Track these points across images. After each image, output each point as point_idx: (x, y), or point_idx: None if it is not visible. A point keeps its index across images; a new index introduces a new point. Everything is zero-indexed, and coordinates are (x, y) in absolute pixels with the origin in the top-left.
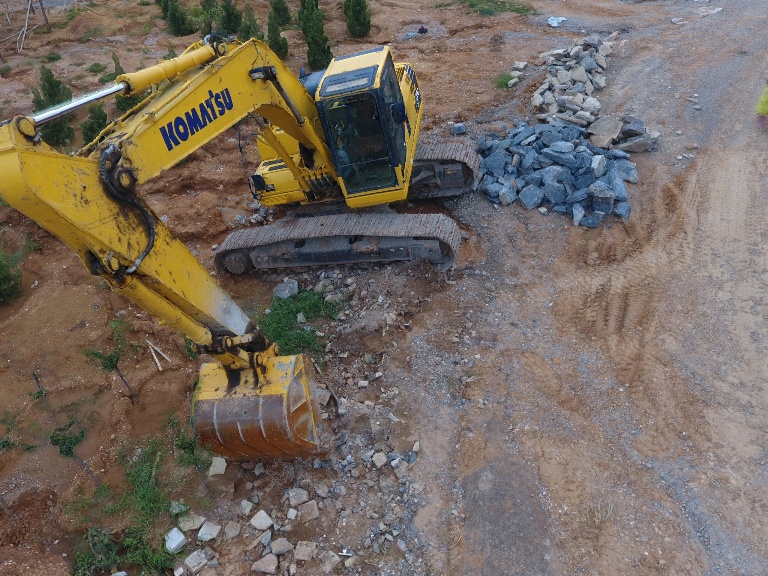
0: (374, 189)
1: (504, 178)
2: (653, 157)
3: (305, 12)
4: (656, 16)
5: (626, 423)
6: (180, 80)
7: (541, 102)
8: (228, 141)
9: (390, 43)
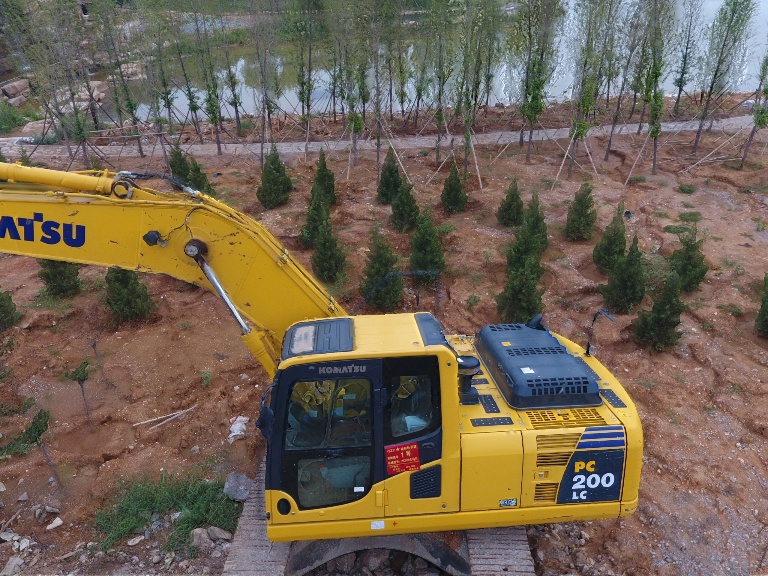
0: None
1: None
2: None
3: None
4: None
5: None
6: (3, 186)
7: None
8: None
9: None
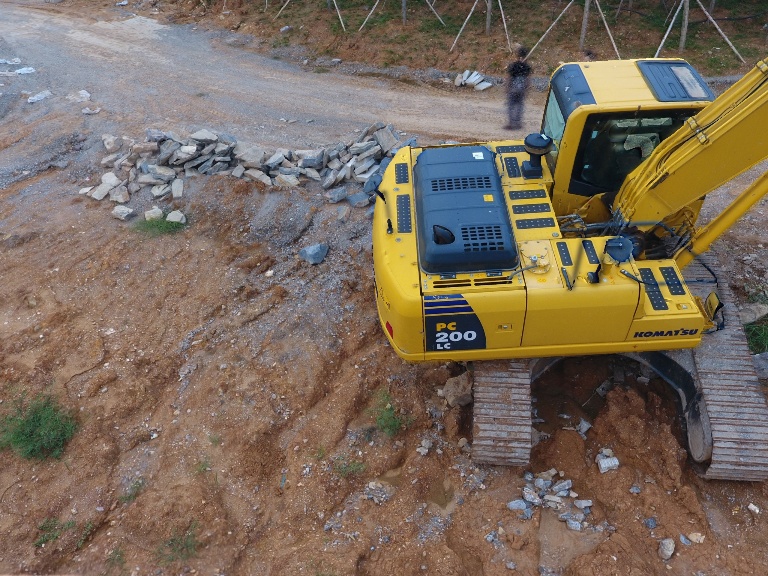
0: None
1: None
2: None
3: None
4: (65, 119)
5: (762, 165)
6: None
7: None
8: None
9: None
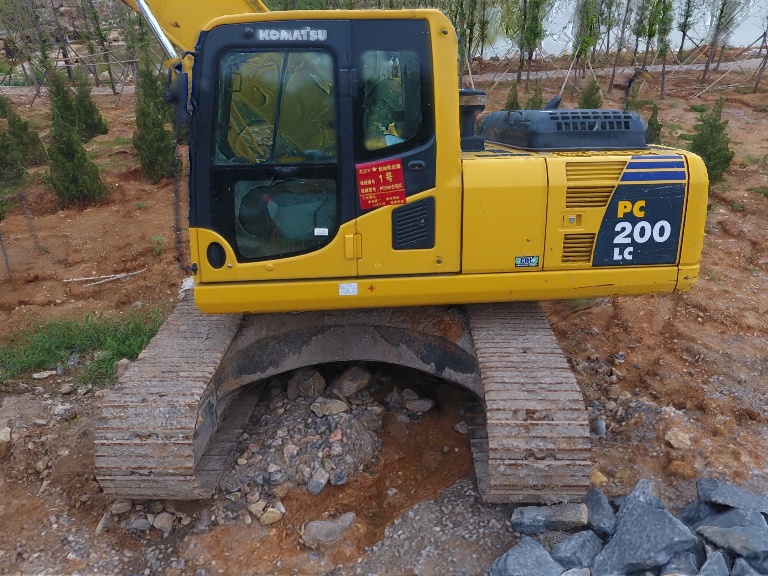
0: None
1: None
2: None
3: None
4: None
5: None
6: None
7: None
8: None
9: None
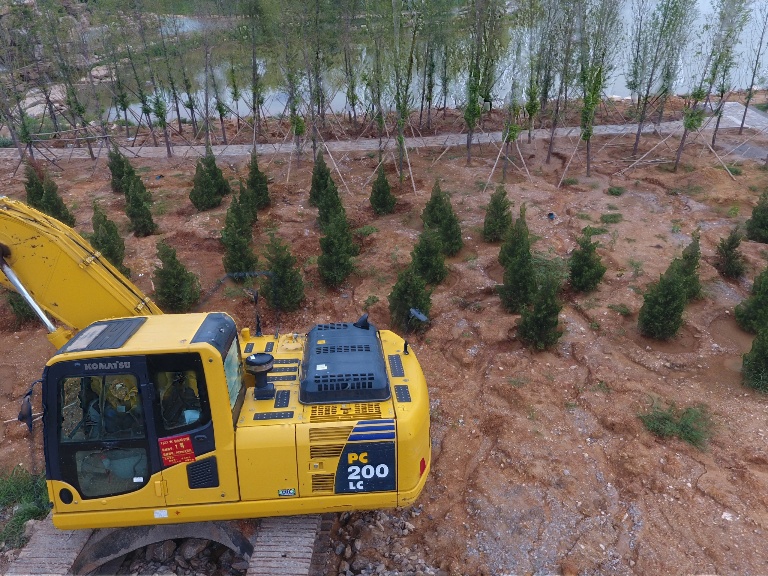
0: None
1: None
2: None
3: None
4: None
5: None
6: None
7: None
8: (468, 349)
9: None
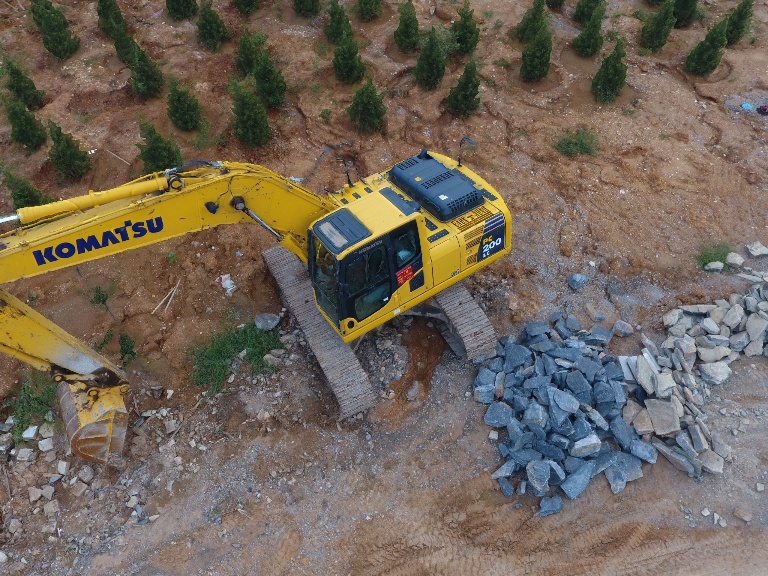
0: (329, 316)
1: (502, 376)
2: (682, 485)
3: (656, 14)
4: None
5: None
6: (93, 212)
7: (671, 323)
8: (423, 132)
9: (712, 103)
